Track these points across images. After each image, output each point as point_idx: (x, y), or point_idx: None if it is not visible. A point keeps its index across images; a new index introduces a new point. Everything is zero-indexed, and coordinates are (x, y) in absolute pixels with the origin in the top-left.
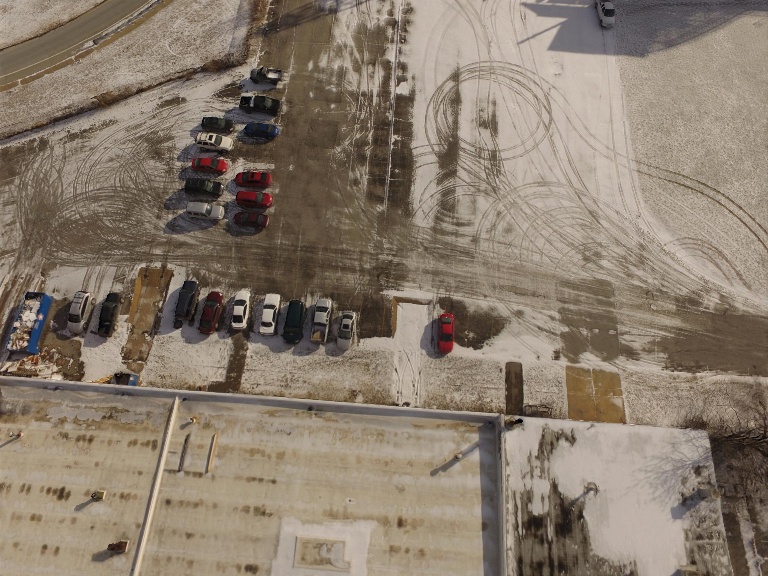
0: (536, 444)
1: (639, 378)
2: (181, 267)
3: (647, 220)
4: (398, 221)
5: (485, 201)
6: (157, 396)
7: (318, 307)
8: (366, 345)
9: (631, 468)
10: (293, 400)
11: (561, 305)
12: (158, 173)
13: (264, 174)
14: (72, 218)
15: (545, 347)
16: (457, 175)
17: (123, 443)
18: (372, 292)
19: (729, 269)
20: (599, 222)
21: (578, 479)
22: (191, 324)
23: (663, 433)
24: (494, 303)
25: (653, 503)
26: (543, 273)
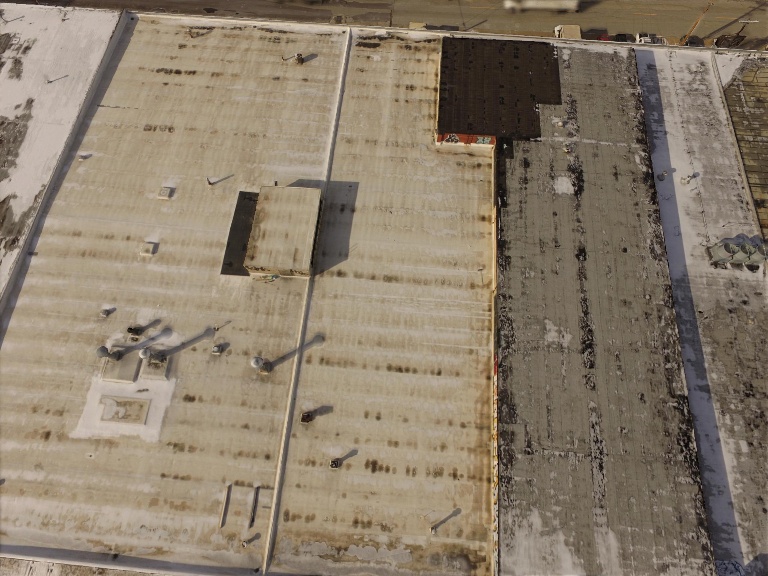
0: None
1: None
2: None
3: None
4: None
5: None
6: (288, 575)
7: None
8: None
9: None
10: (129, 568)
11: None
12: None
13: None
14: None
15: None
16: None
17: (320, 519)
18: None
19: None
20: None
21: None
22: None
23: None
24: None
25: None
26: None
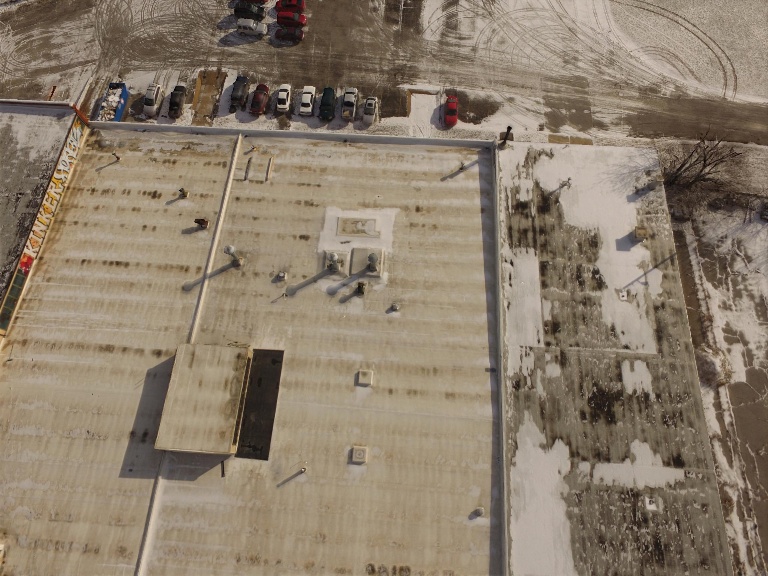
0: (523, 158)
1: (608, 142)
2: (233, 70)
3: (617, 34)
4: (411, 37)
5: (482, 22)
6: (224, 134)
7: (347, 92)
8: (386, 122)
9: (596, 172)
10: (332, 133)
11: (545, 93)
12: (211, 3)
13: (299, 0)
14: (141, 36)
15: (532, 122)
16: (459, 4)
17: (200, 164)
18: (390, 86)
19: (683, 68)
20: (577, 36)
21: (555, 179)
22: (243, 110)
23: (622, 150)
24: (490, 92)
25: (613, 193)
26: (530, 72)
